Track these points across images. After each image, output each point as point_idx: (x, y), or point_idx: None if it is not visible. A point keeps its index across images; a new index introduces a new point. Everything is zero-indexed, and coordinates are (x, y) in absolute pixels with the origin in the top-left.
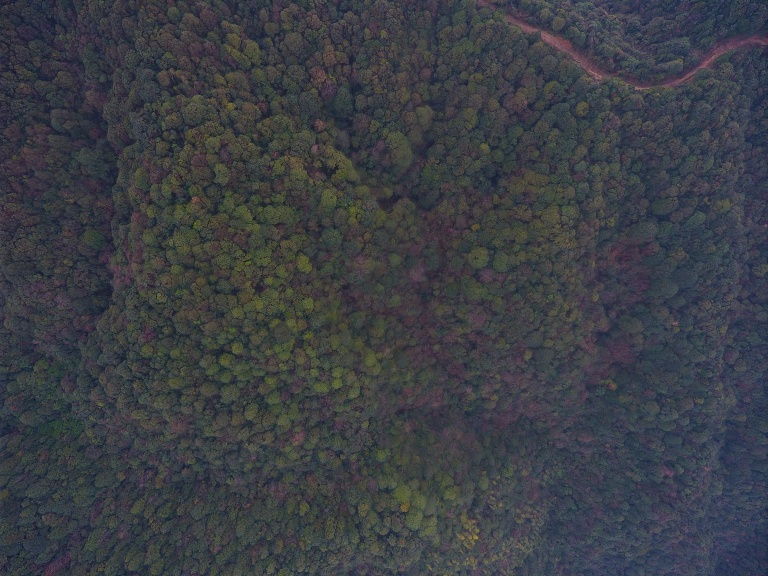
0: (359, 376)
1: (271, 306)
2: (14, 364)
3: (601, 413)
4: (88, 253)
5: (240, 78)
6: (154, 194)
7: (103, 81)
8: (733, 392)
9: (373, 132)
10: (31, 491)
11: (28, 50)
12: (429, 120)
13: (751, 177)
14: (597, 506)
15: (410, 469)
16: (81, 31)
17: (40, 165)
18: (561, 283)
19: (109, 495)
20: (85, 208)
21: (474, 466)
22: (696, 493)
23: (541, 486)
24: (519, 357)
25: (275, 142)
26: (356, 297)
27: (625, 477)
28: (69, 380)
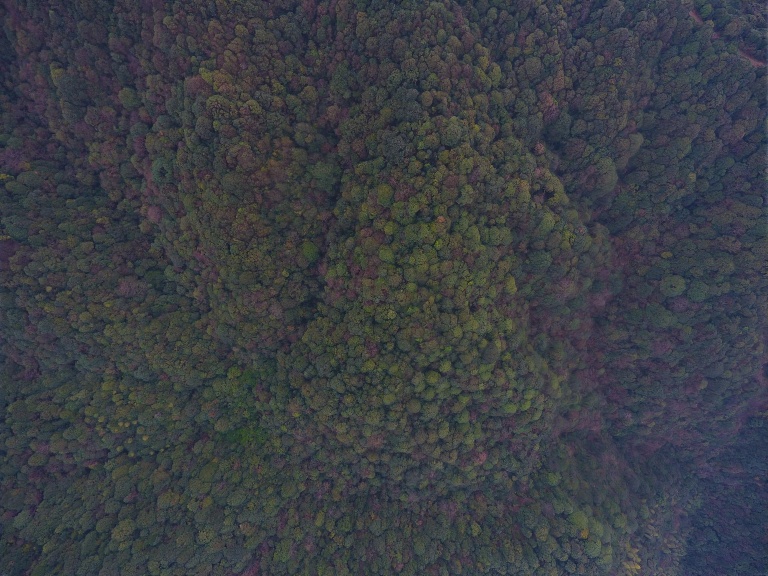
0: (546, 399)
1: (484, 326)
2: (211, 370)
3: (753, 445)
4: (304, 265)
5: (485, 100)
6: (399, 212)
7: (347, 97)
8: None
9: (585, 157)
10: (234, 499)
11: (284, 64)
12: (638, 147)
13: None
14: (744, 540)
15: (582, 494)
16: (337, 48)
17: (282, 177)
18: None
19: (292, 506)
20: (308, 220)
21: (631, 493)
22: None
23: (681, 516)
24: (690, 386)
25: (510, 164)
26: (542, 319)
27: None
28: (262, 389)
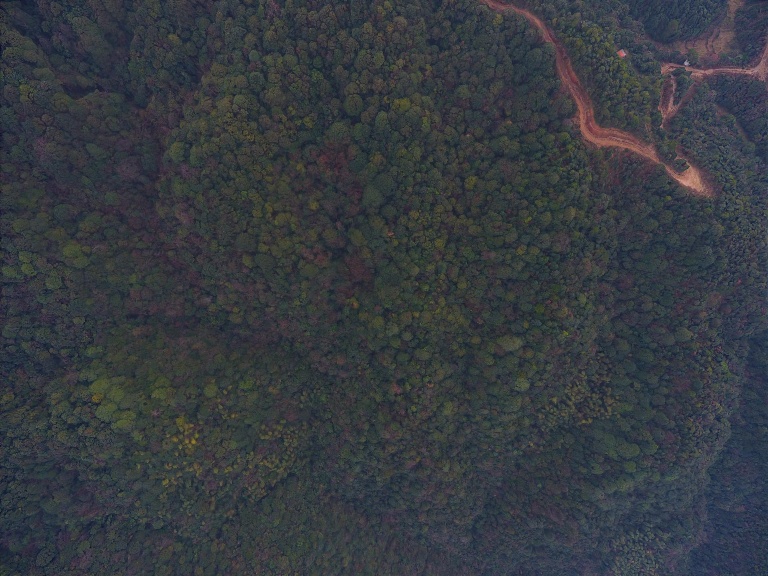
0: (55, 265)
1: None
2: None
3: (352, 334)
4: None
5: None
6: None
7: None
8: (459, 311)
9: (57, 15)
10: None
11: None
12: (119, 8)
13: (441, 81)
14: (346, 428)
15: (119, 366)
16: None
17: None
18: (257, 181)
19: None
20: None
21: (208, 375)
22: (424, 412)
23: (302, 409)
24: None
25: None
26: (63, 189)
27: (371, 398)
28: None
